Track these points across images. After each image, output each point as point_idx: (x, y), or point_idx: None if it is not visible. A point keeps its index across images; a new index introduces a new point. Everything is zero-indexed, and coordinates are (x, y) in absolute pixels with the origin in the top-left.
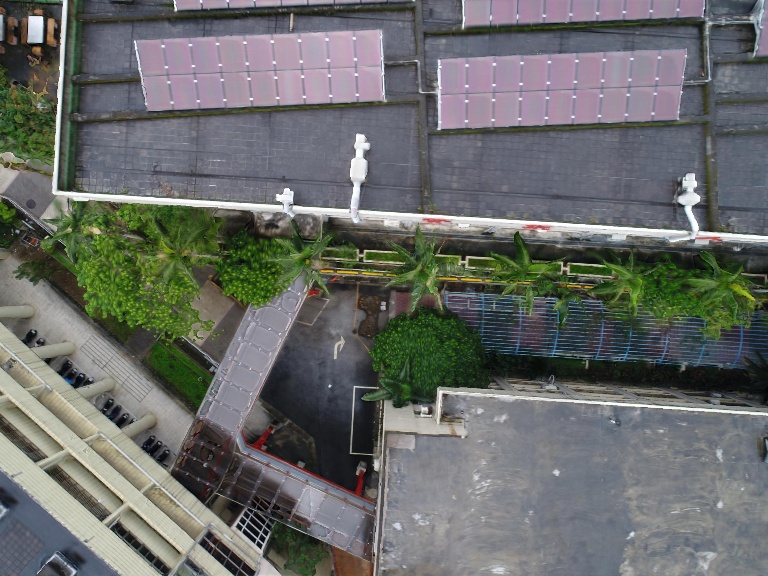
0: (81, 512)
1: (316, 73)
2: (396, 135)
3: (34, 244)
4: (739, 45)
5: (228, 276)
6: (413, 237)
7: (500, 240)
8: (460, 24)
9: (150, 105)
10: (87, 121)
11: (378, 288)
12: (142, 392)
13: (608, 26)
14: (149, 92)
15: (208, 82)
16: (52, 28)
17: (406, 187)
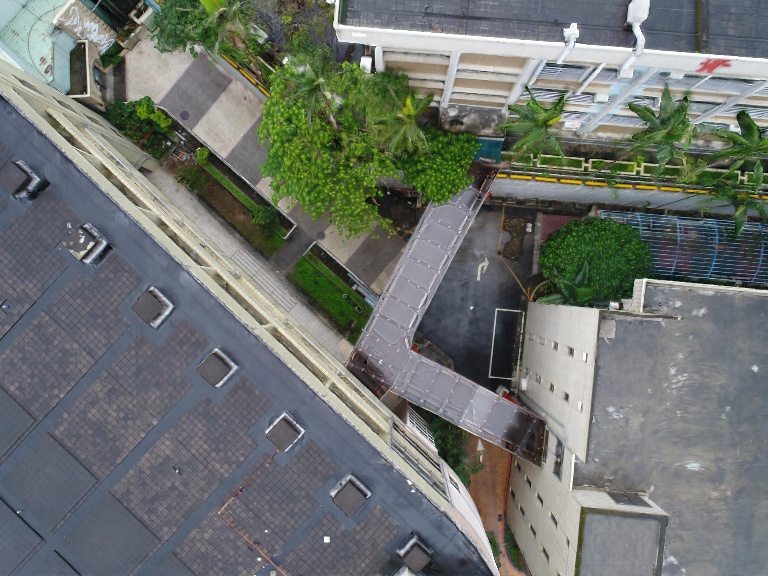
0: (309, 373)
1: None
2: None
3: (182, 158)
4: None
5: (421, 165)
6: (584, 145)
7: None
8: None
9: None
10: None
11: (524, 210)
12: (286, 307)
13: None
14: None
15: None
16: None
17: (680, 33)
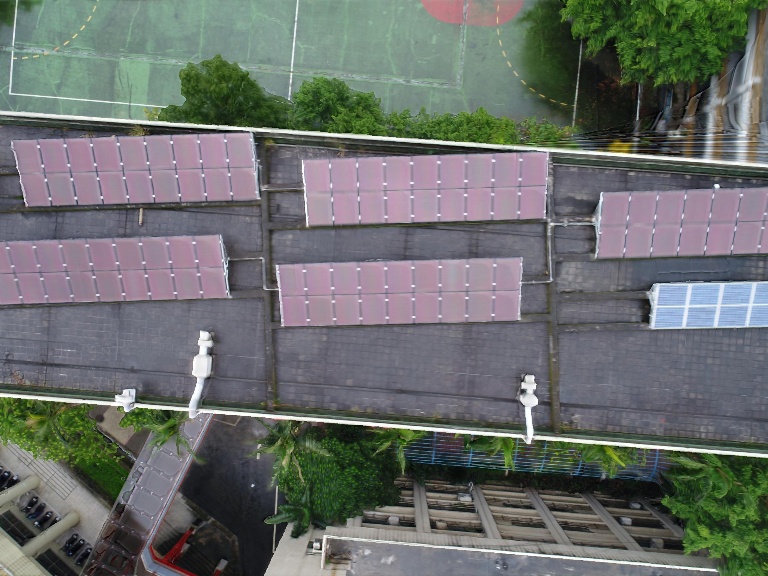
0: None
1: (159, 273)
2: (243, 328)
3: None
4: (583, 244)
5: None
6: None
7: None
8: (305, 222)
9: None
10: None
11: None
12: (66, 490)
13: (452, 225)
14: None
15: (54, 280)
16: None
17: (252, 379)
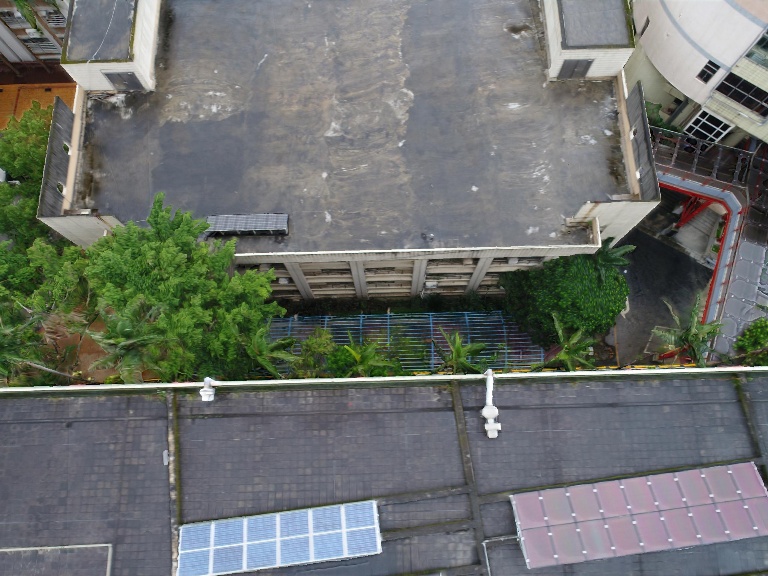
0: None
1: None
2: None
3: None
4: None
5: None
6: None
7: None
8: None
9: None
10: None
11: None
12: None
13: None
14: None
15: None
16: None
17: (765, 402)
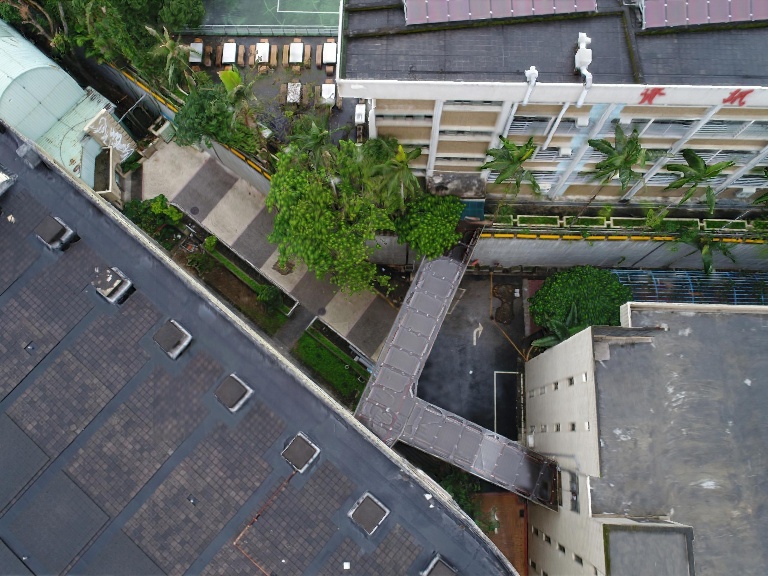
0: None
1: None
2: (607, 37)
3: (190, 250)
4: None
5: (413, 221)
6: (557, 207)
7: (636, 206)
8: None
9: (410, 20)
10: (355, 37)
11: (510, 277)
12: None
13: None
14: (410, 10)
15: None
16: (242, 52)
17: (620, 74)
